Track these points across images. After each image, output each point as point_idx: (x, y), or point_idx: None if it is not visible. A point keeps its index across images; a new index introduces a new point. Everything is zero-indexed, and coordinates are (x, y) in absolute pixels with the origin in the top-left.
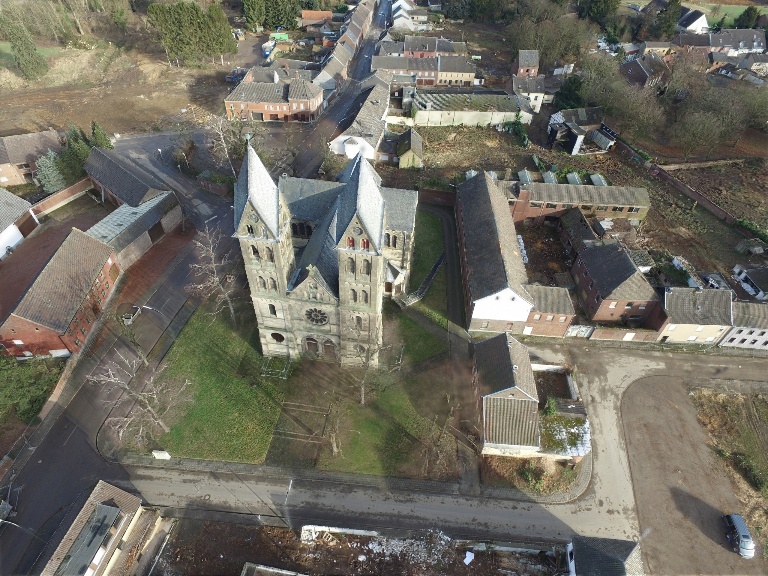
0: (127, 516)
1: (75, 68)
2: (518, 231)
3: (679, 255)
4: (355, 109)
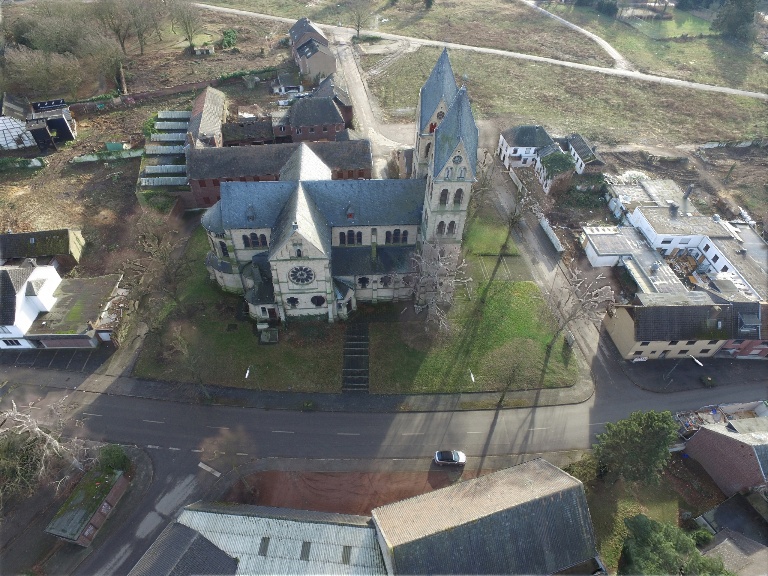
0: None
1: None
2: None
3: (261, 107)
4: None
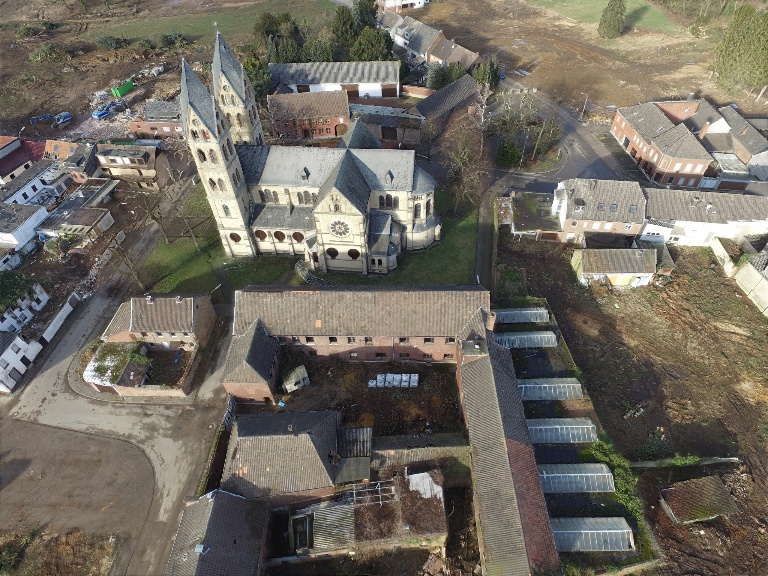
0: (146, 166)
1: (648, 44)
2: (442, 386)
3: None
4: (659, 188)
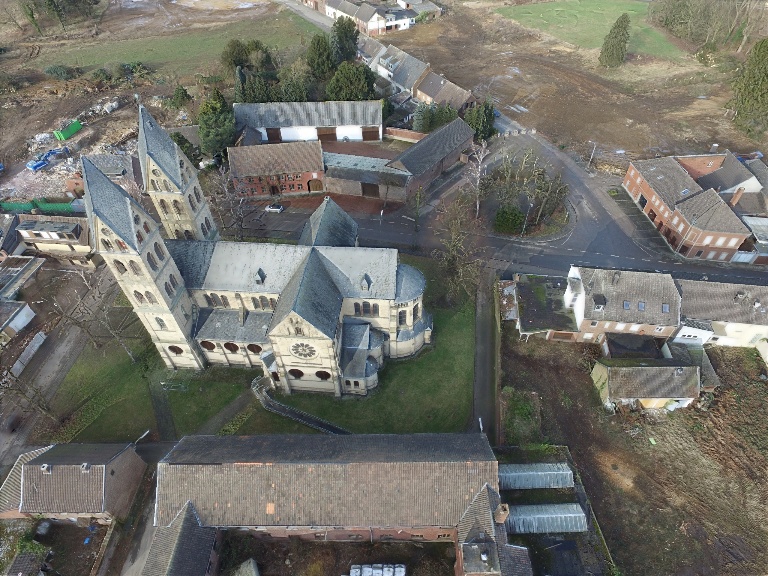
0: (78, 241)
1: (654, 74)
2: None
3: None
4: None
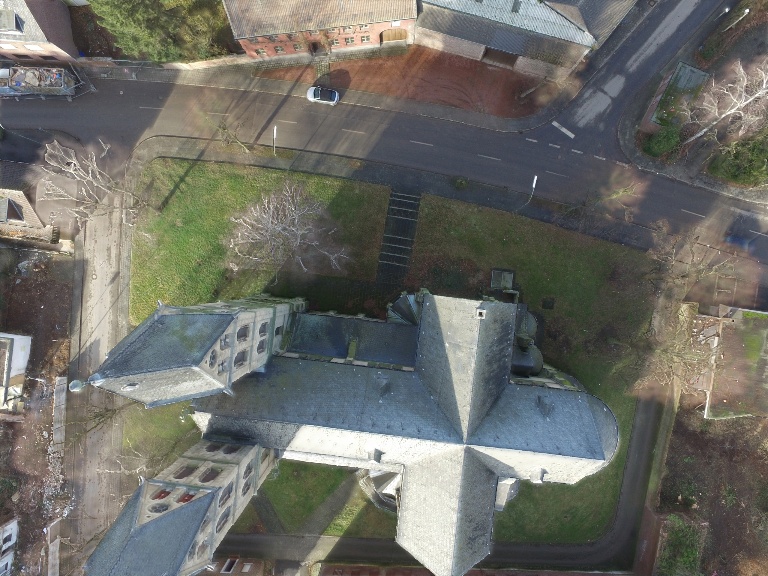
0: (25, 222)
1: None
2: None
3: None
4: None
